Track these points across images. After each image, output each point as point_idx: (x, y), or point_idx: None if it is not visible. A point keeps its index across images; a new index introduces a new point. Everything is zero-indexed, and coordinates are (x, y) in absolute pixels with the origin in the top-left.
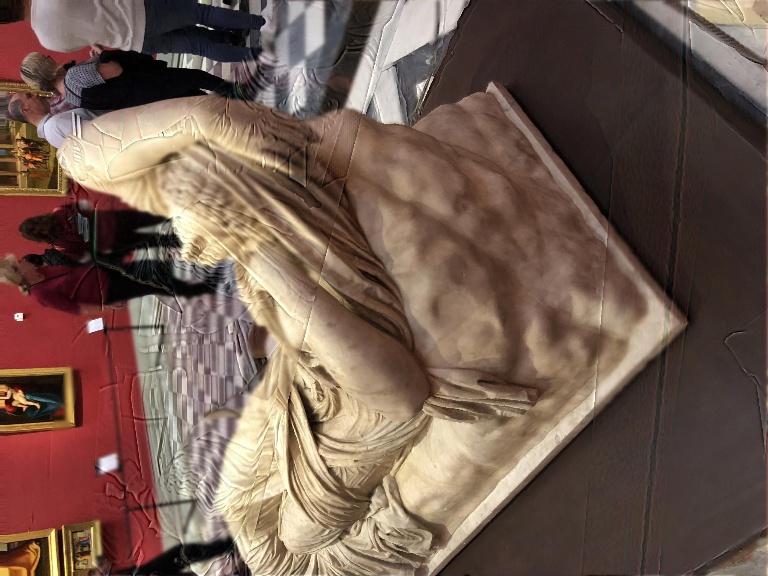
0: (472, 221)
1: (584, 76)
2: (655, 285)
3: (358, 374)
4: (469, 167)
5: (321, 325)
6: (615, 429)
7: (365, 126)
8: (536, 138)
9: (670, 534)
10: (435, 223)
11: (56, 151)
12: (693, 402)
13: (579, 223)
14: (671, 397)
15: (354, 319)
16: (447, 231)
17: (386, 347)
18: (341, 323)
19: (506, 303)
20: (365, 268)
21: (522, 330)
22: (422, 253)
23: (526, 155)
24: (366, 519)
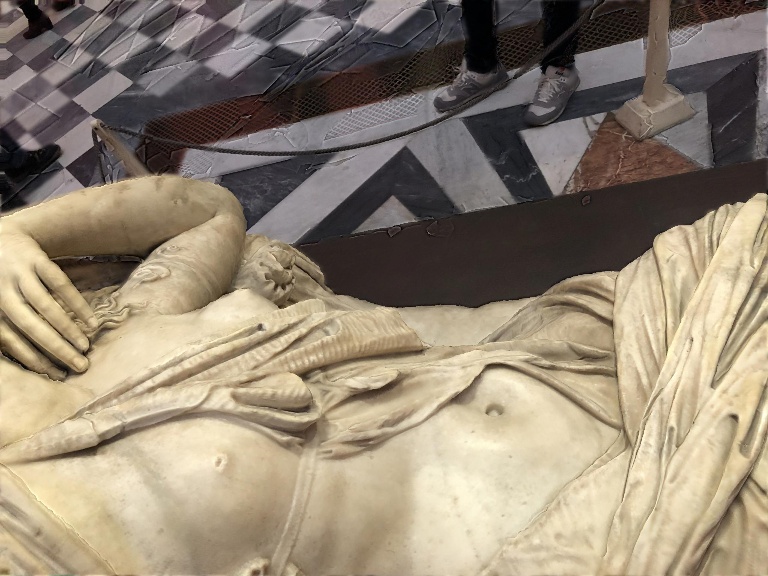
0: None
1: None
2: None
3: None
4: None
5: None
6: None
7: None
8: None
9: (384, 253)
10: None
11: None
12: None
13: None
14: None
15: None
16: None
17: None
18: None
19: None
20: None
21: None
22: None
23: None
24: None
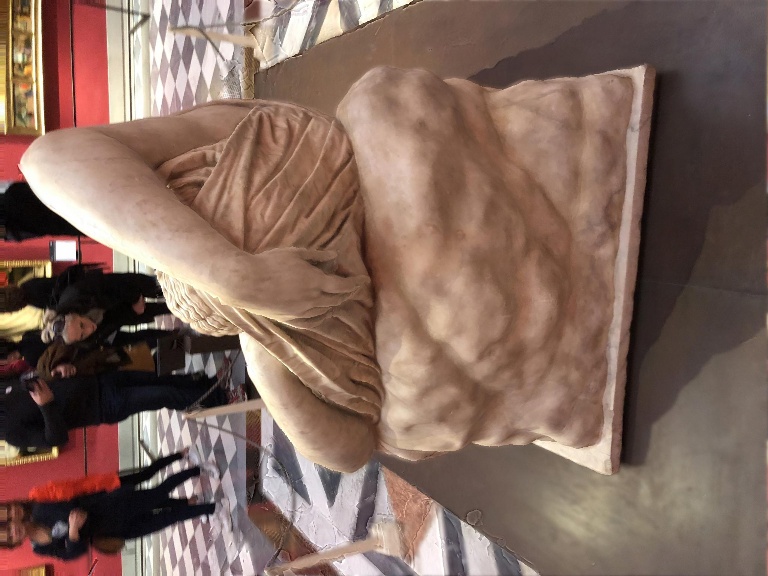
0: (489, 368)
1: (734, 187)
2: None
3: (314, 459)
4: (527, 277)
5: (294, 430)
6: None
7: (434, 226)
8: (634, 198)
9: (506, 519)
10: (450, 370)
11: (18, 172)
12: (580, 495)
13: (601, 336)
14: None
15: (329, 423)
16: (458, 375)
17: (349, 444)
18: (314, 431)
19: (478, 424)
20: (360, 378)
21: (479, 438)
22: (421, 395)
23: (607, 225)
24: None
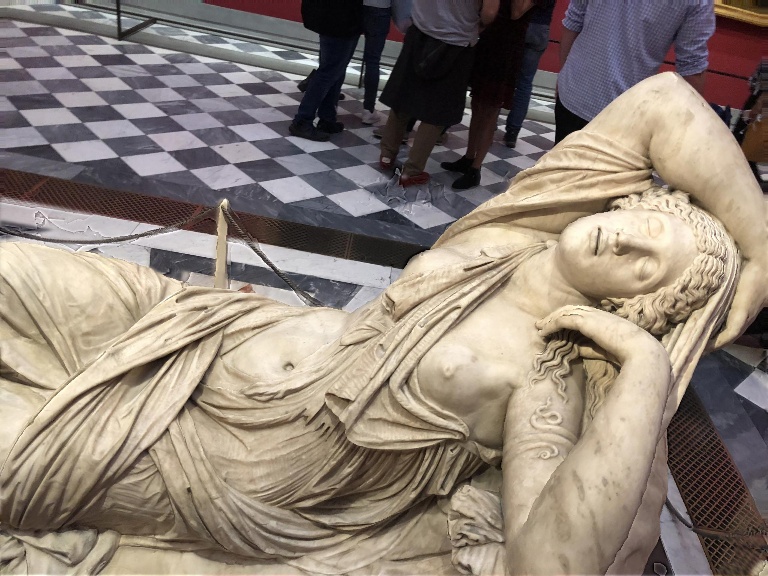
0: None
1: None
2: None
3: (621, 518)
4: None
5: (653, 446)
6: None
7: None
8: None
9: None
10: None
11: None
12: None
13: None
14: None
15: None
16: None
17: None
18: None
19: None
20: None
21: None
22: None
23: None
24: (11, 536)
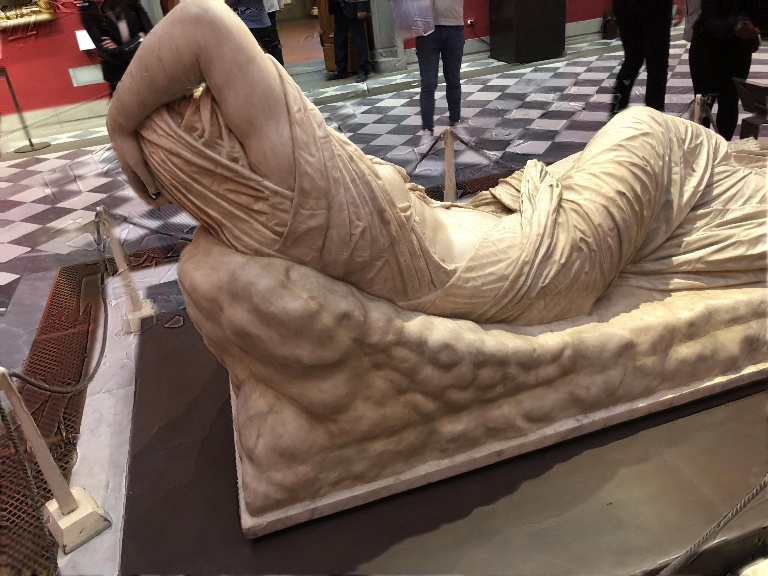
0: None
1: None
2: (16, 123)
3: None
4: None
5: None
6: (40, 104)
7: None
8: None
9: None
10: None
11: None
12: None
13: None
14: (46, 127)
15: None
16: None
17: None
18: None
19: None
20: None
21: None
22: None
23: None
24: None
